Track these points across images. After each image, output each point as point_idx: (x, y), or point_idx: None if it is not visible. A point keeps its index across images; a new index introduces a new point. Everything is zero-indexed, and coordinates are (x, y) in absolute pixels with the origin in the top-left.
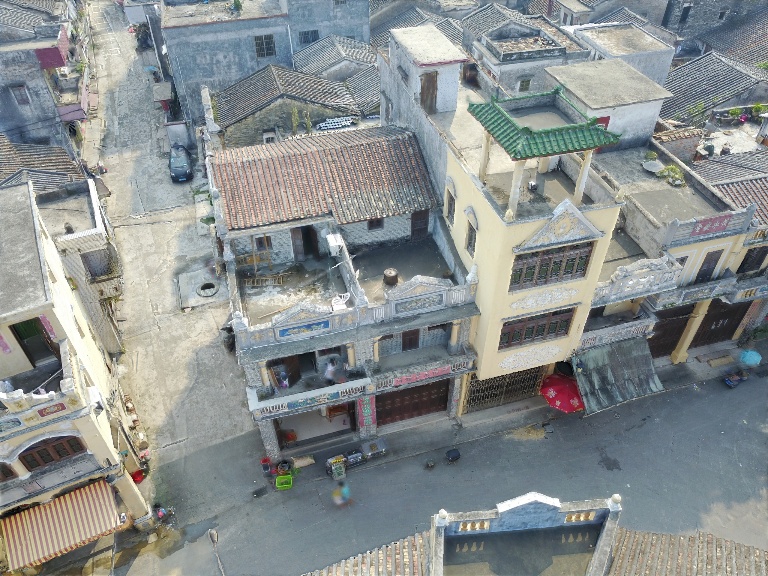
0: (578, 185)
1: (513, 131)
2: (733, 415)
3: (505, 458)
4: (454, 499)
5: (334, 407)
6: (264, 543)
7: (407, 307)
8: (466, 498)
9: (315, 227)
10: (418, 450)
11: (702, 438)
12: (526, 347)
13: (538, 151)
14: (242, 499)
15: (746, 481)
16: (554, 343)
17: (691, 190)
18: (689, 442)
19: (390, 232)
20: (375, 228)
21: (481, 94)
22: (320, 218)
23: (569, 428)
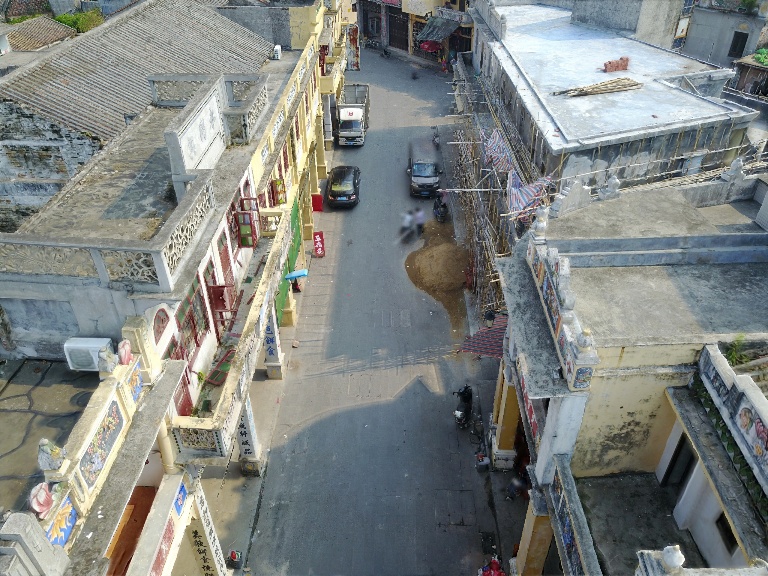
0: None
1: None
2: None
3: None
4: None
5: None
6: None
7: None
8: None
9: None
10: None
11: None
12: None
13: None
14: None
15: (435, 98)
16: (424, 1)
17: None
18: (446, 88)
19: None
20: None
21: None
22: None
23: (427, 71)
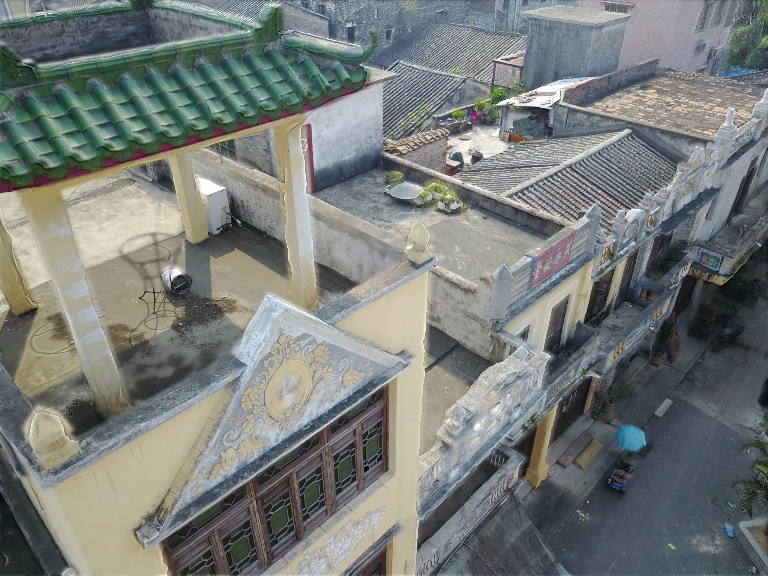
0: (292, 244)
1: None
2: (651, 542)
3: None
4: None
5: None
6: None
7: None
8: None
9: None
10: None
11: None
12: None
13: (85, 142)
14: None
15: None
16: None
17: (477, 213)
18: None
19: None
20: None
21: None
22: None
23: None
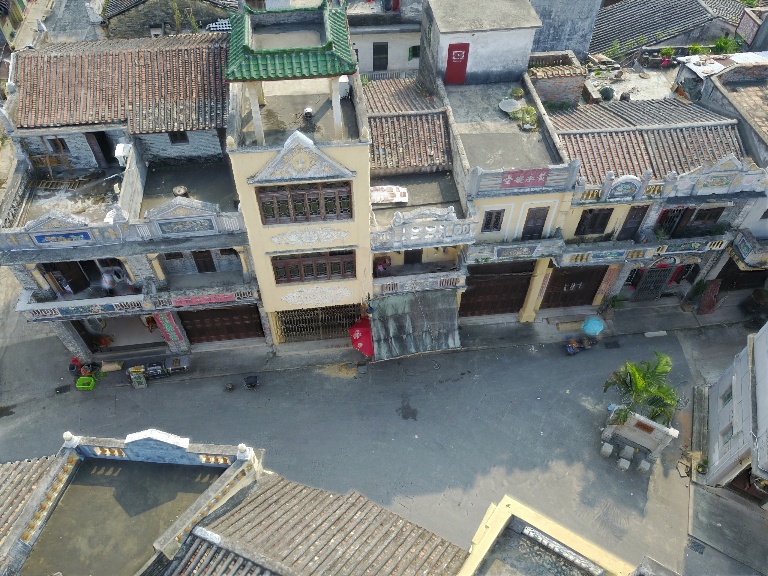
0: (334, 117)
1: (242, 48)
2: (558, 383)
3: (306, 392)
4: (240, 423)
5: (153, 319)
6: (48, 436)
7: (174, 228)
8: (251, 424)
9: (108, 134)
10: (224, 371)
11: (514, 401)
12: (308, 284)
13: (258, 74)
14: (44, 393)
15: (539, 450)
16: (341, 284)
17: (539, 137)
18: (499, 403)
19: (198, 148)
20: (180, 142)
21: (333, 4)
22: (114, 125)
23: (383, 372)
